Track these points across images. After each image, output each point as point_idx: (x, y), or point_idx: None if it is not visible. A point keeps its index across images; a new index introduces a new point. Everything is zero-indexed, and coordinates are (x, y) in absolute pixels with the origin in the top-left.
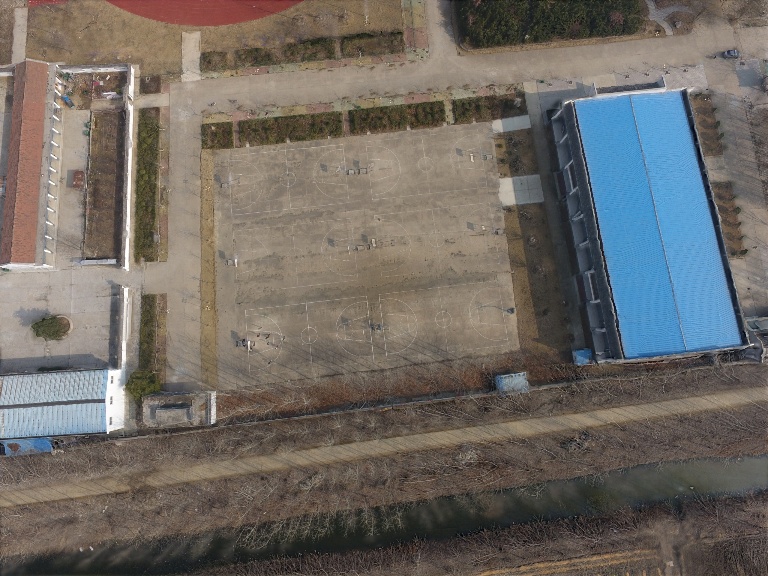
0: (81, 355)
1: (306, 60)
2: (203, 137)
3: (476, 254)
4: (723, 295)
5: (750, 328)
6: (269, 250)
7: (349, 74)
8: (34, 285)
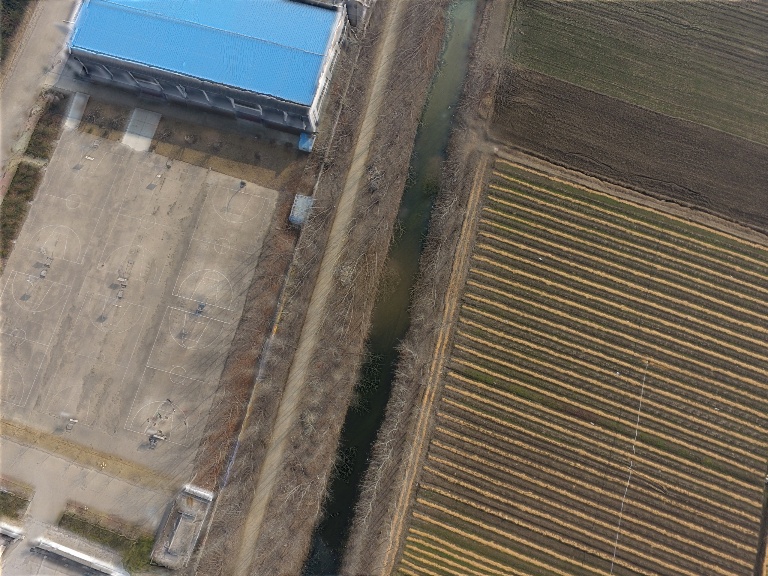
0: None
1: None
2: None
3: (179, 193)
4: (299, 8)
5: (341, 3)
6: (78, 383)
7: None
8: None
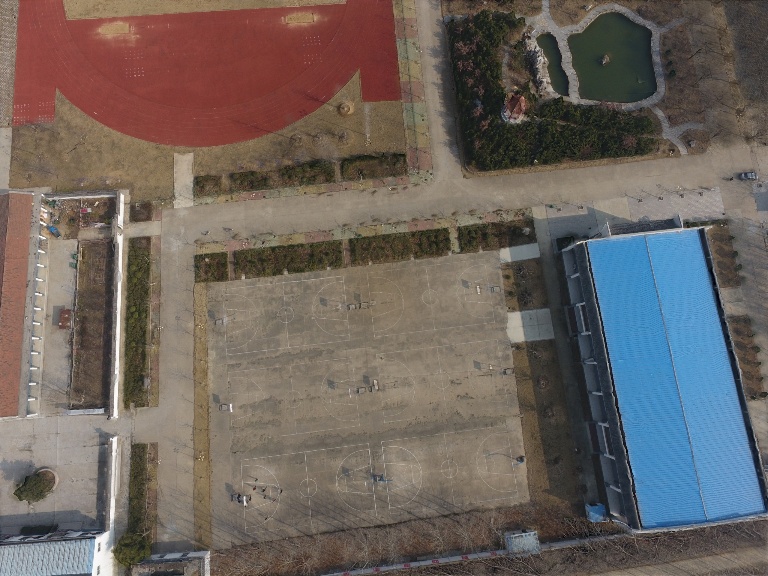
0: (67, 512)
1: (304, 184)
2: (196, 269)
3: (483, 396)
4: (744, 454)
5: None
6: (266, 393)
7: (350, 199)
8: (17, 434)
